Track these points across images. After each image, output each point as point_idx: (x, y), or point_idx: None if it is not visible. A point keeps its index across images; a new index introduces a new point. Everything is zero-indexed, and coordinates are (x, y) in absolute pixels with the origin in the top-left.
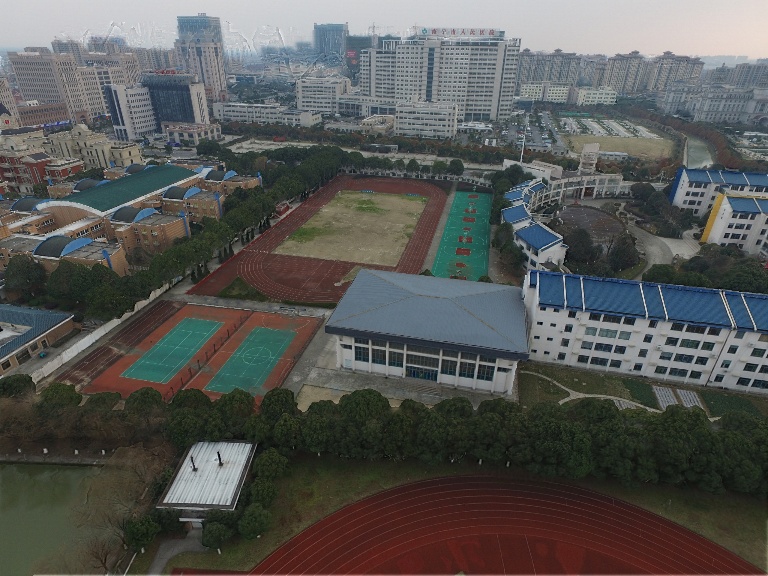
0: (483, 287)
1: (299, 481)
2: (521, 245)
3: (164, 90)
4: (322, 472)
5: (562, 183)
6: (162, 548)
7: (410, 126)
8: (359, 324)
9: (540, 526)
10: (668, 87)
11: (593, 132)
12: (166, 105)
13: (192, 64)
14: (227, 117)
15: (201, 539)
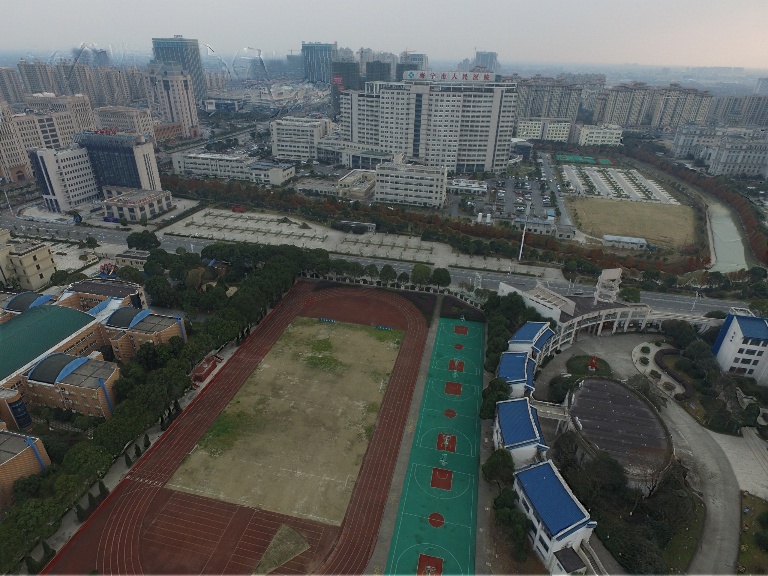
0: None
1: None
2: (525, 501)
3: (105, 151)
4: None
5: (574, 322)
6: None
7: (392, 191)
8: None
9: None
10: (678, 129)
11: (600, 193)
12: (108, 168)
13: (159, 98)
14: (188, 169)
15: None
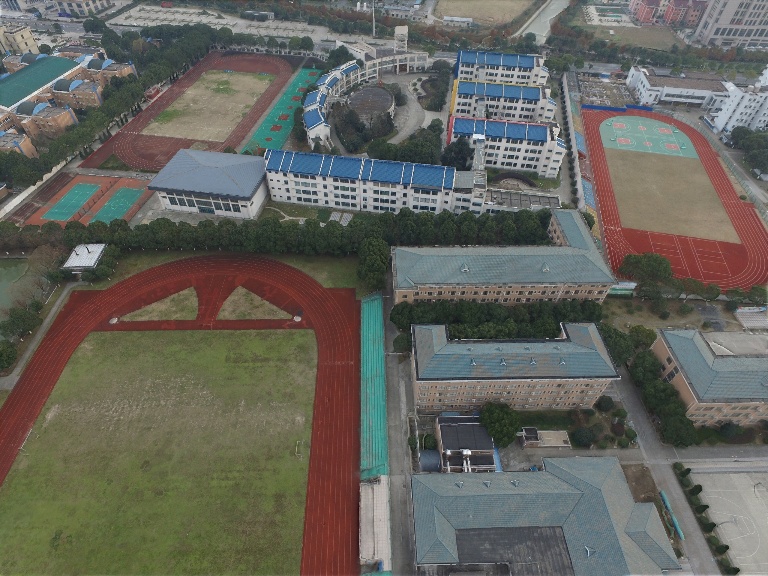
0: (248, 159)
1: (132, 260)
2: None
3: None
4: (143, 256)
5: (376, 63)
6: (68, 285)
7: None
8: (166, 184)
9: (234, 271)
10: None
11: None
12: None
13: None
14: None
15: (85, 281)
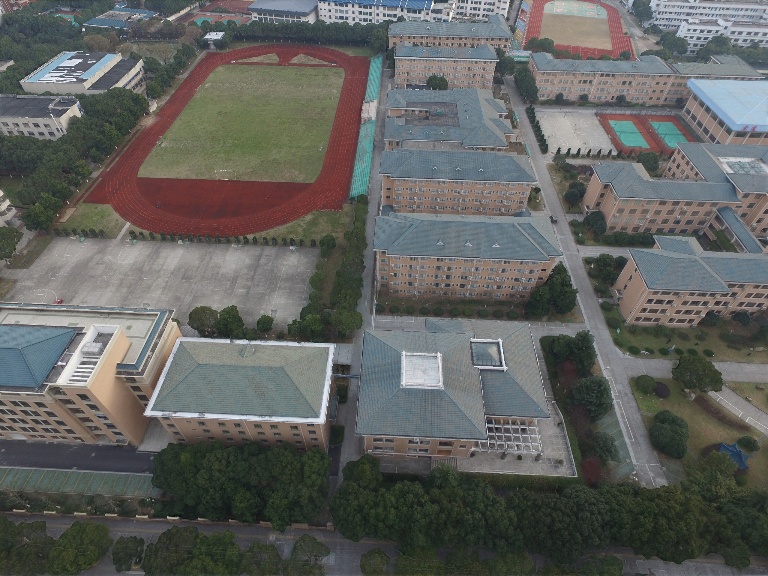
0: None
1: (238, 44)
2: None
3: None
4: (245, 43)
5: None
6: (204, 50)
7: None
8: (258, 7)
9: (298, 49)
10: None
11: None
12: None
13: None
14: None
15: None
